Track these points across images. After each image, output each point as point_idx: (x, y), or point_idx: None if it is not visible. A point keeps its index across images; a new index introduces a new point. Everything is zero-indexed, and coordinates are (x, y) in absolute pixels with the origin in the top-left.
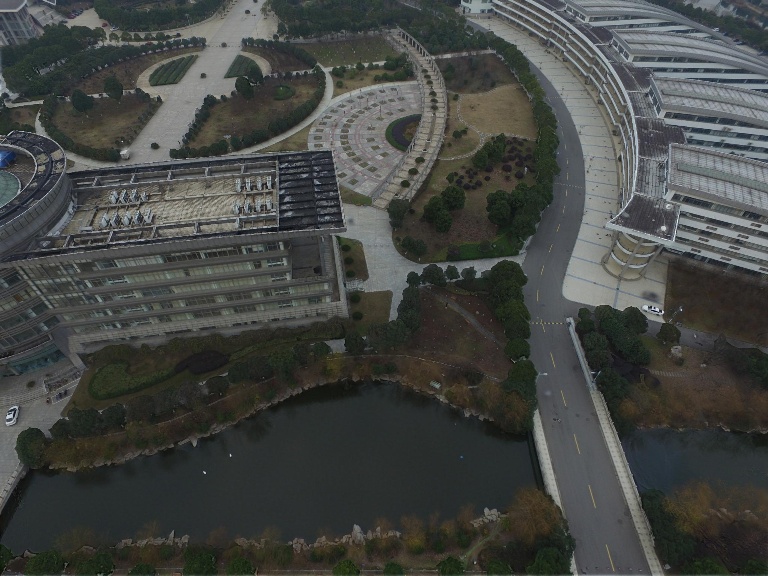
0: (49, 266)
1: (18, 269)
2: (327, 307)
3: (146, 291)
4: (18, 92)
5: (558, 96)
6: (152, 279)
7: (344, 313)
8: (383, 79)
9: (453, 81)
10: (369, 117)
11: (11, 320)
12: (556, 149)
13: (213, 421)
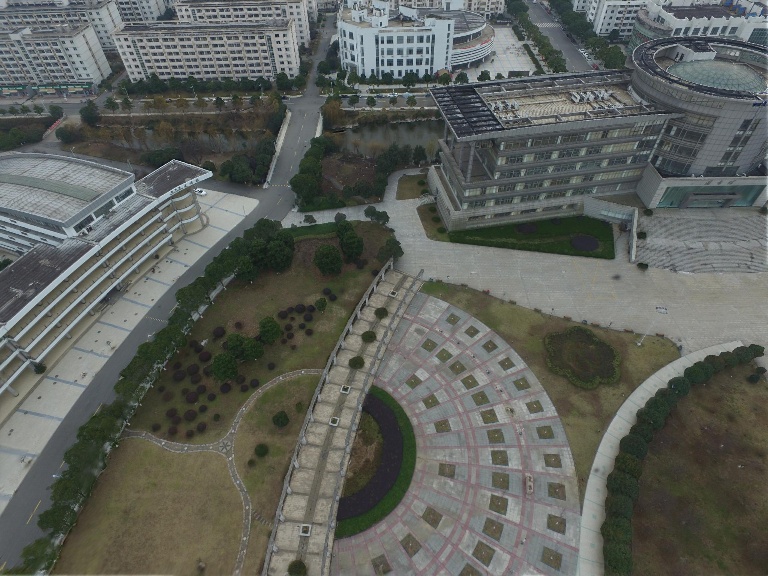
0: None
1: None
2: None
3: None
4: None
5: None
6: None
7: None
8: None
9: None
10: (459, 524)
11: None
12: None
13: None
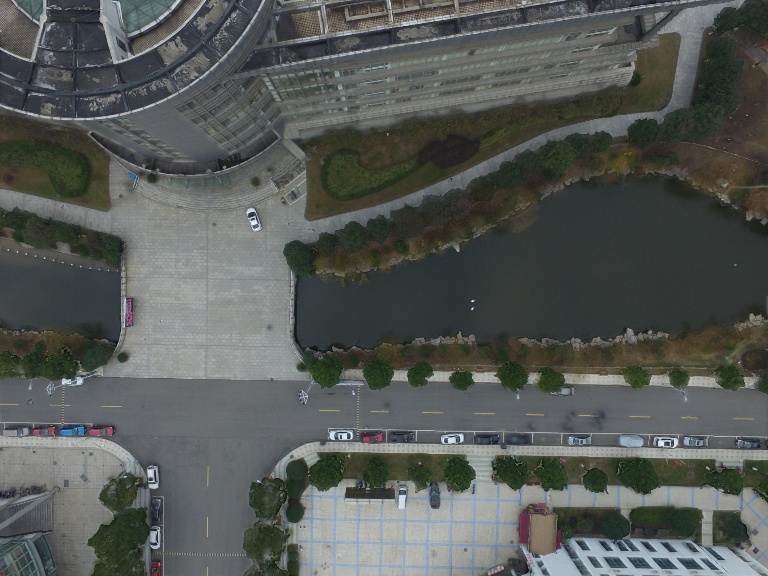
0: None
1: None
2: (611, 75)
3: (404, 75)
4: None
5: None
6: (421, 62)
7: (626, 81)
8: None
9: None
10: None
11: (242, 126)
12: None
13: None
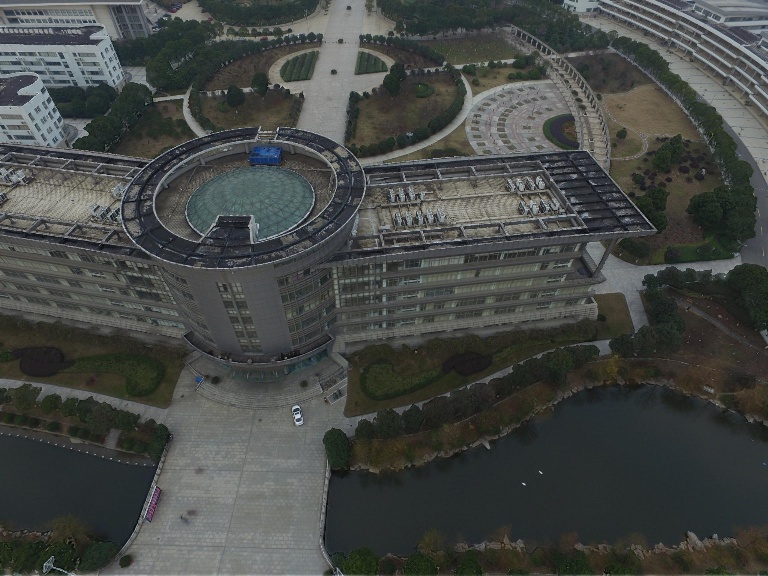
0: (362, 265)
1: (333, 268)
2: (581, 309)
3: (430, 291)
4: (156, 86)
5: (701, 97)
6: (443, 279)
7: (594, 315)
8: (517, 77)
9: (592, 80)
10: (519, 116)
11: (310, 319)
12: (735, 151)
13: (497, 423)
